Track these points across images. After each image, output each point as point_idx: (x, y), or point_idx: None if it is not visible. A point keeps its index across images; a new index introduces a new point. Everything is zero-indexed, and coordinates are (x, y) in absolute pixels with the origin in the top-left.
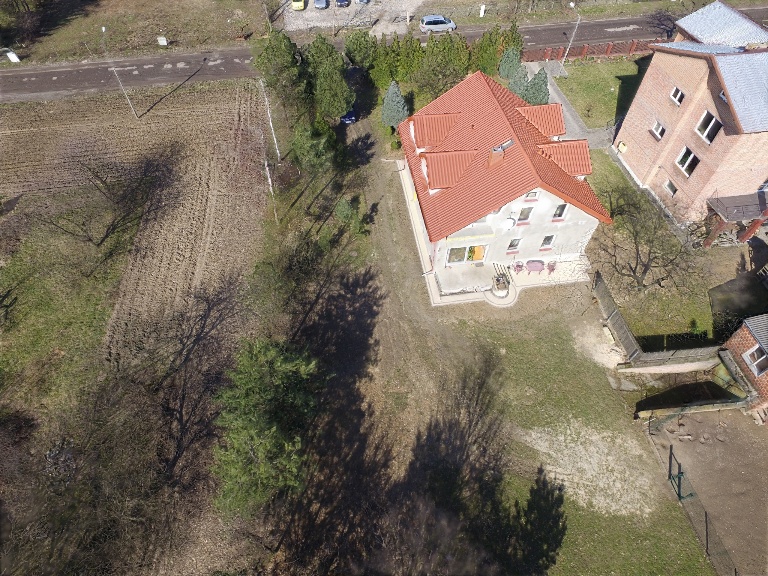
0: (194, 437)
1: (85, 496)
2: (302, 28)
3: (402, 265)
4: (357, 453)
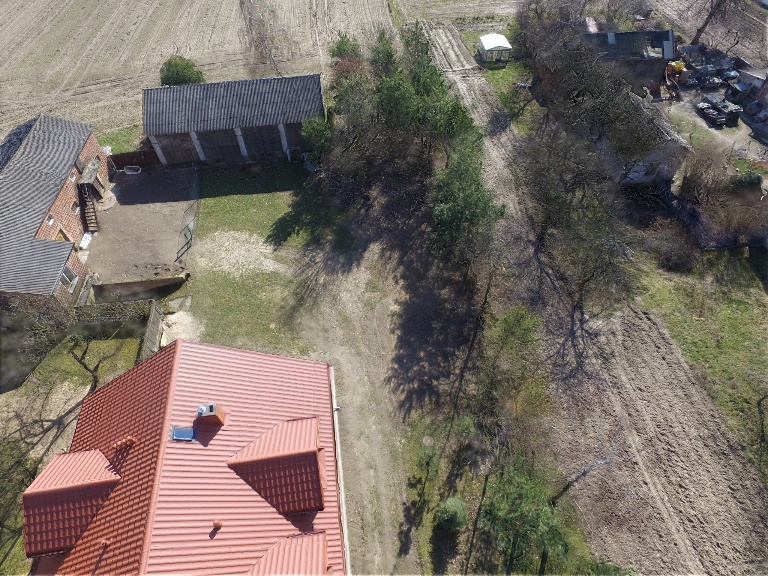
0: (529, 262)
1: (585, 234)
2: None
3: (364, 425)
4: (404, 255)
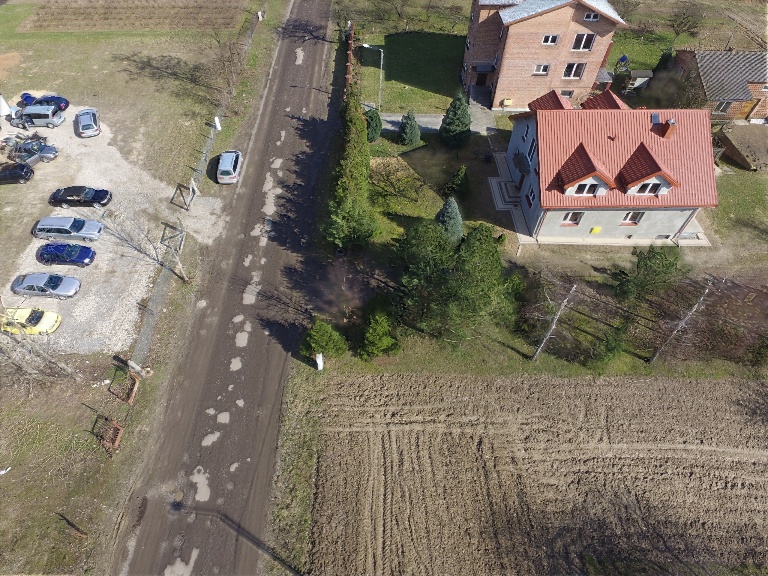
0: None
1: None
2: (133, 324)
3: None
4: None
